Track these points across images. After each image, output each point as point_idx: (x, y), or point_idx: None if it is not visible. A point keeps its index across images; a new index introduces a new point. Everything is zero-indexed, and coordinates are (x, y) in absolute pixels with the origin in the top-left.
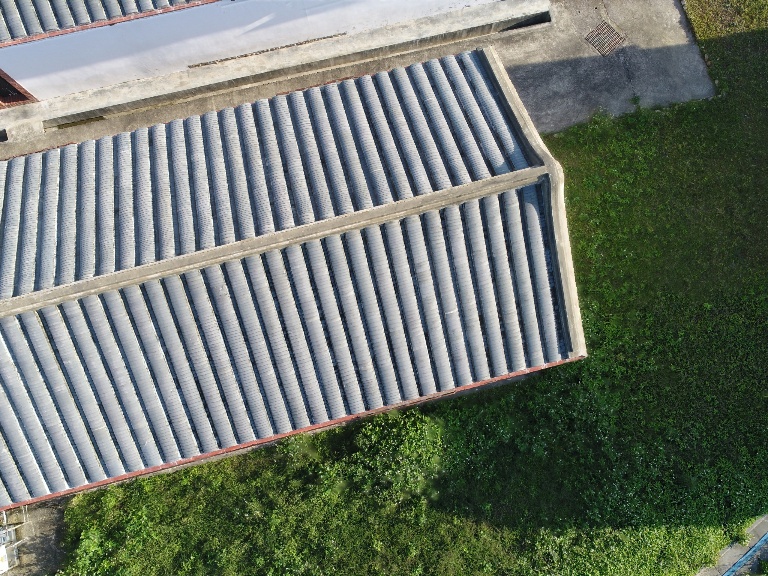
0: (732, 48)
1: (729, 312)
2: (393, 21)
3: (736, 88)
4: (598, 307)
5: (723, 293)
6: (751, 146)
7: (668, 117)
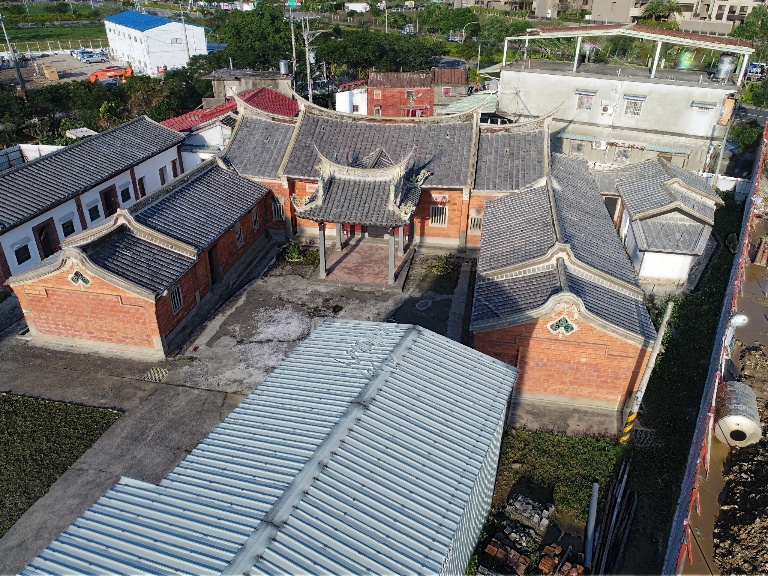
0: None
1: None
2: None
3: None
4: None
5: None
6: None
7: None
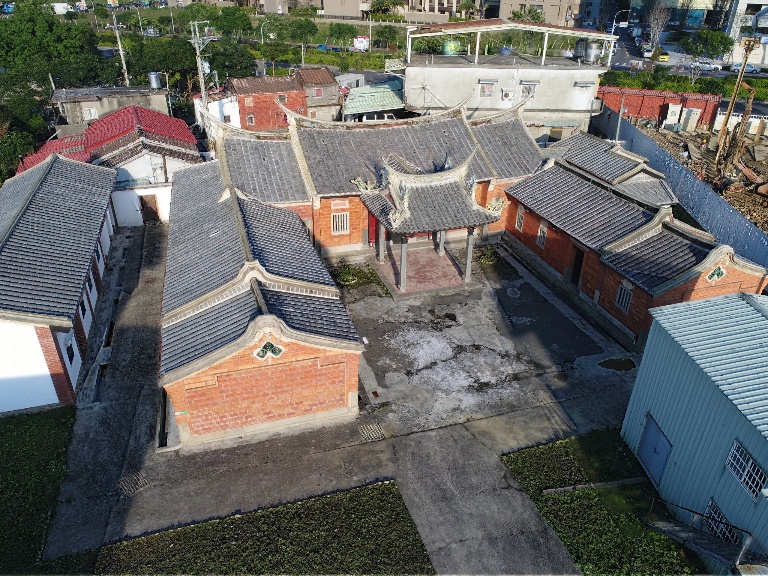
0: (80, 572)
1: None
2: None
3: (38, 573)
4: None
5: None
6: None
7: None
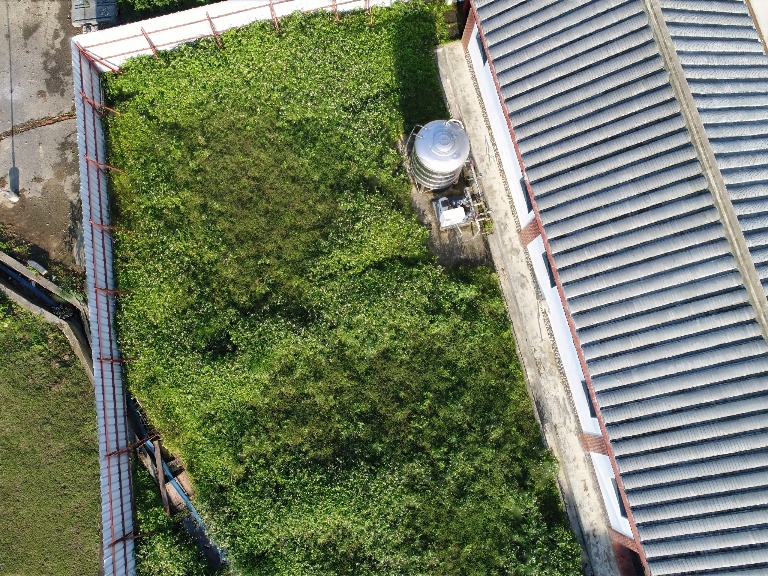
0: None
1: None
2: None
3: None
4: None
5: None
6: None
7: None
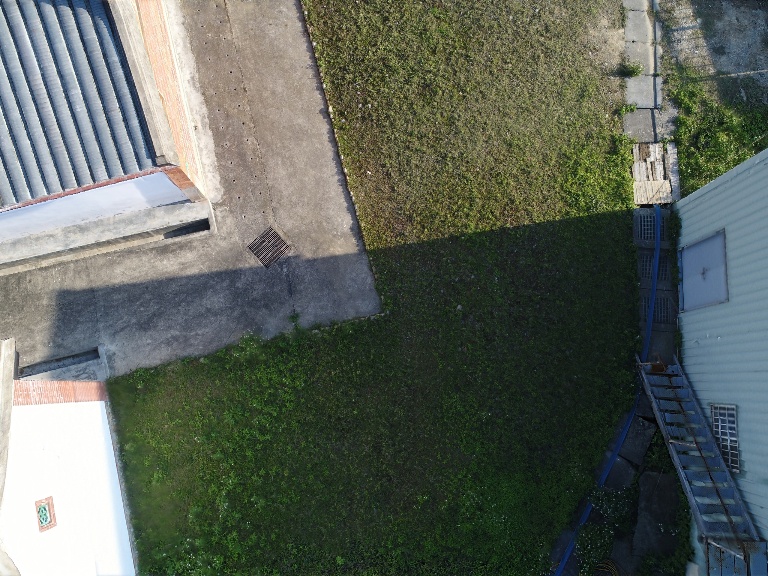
0: (401, 260)
1: (365, 566)
2: (35, 231)
3: (401, 306)
4: (221, 562)
5: (360, 544)
6: (408, 374)
7: (325, 339)
